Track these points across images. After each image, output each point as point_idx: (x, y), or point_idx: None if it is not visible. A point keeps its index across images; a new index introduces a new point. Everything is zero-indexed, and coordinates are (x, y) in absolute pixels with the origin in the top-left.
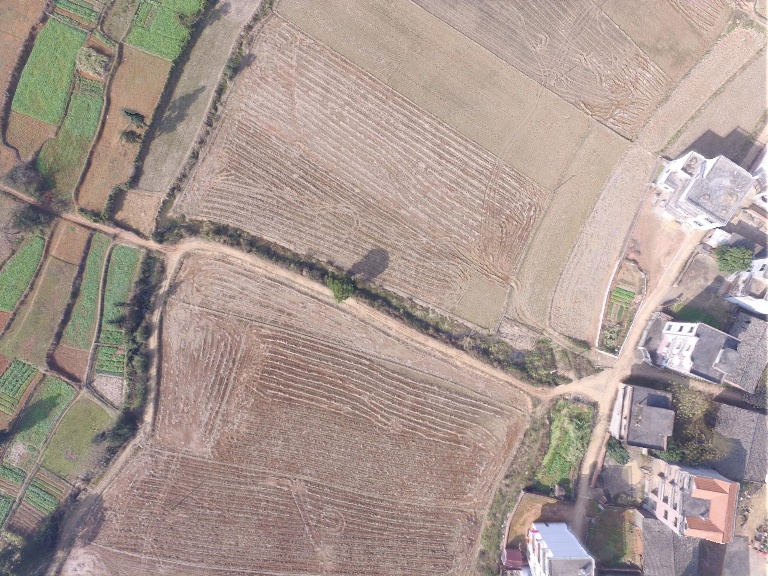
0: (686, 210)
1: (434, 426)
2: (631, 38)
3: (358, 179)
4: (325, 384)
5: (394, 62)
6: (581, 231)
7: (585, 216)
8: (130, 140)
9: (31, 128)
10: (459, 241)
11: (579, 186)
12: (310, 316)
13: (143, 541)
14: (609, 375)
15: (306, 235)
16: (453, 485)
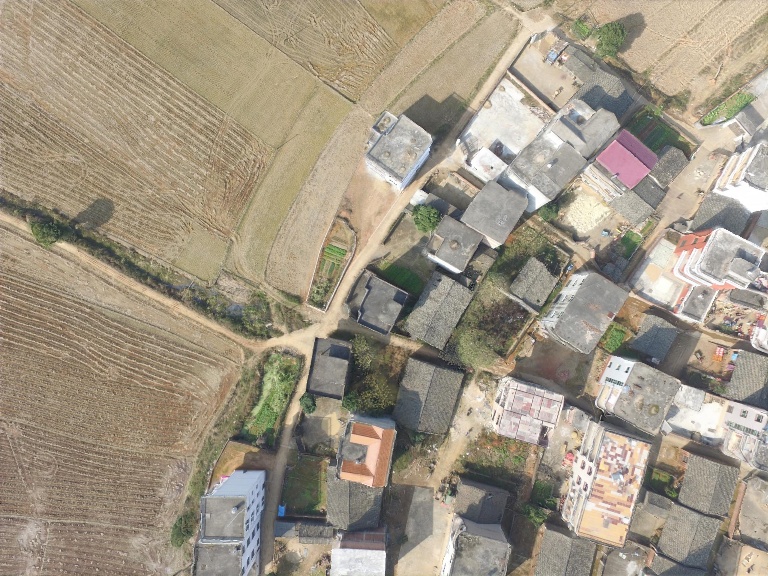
0: (376, 168)
1: (150, 374)
2: (360, 2)
3: (88, 129)
4: (45, 330)
5: (129, 15)
6: (300, 189)
7: (306, 174)
8: None
9: None
10: (184, 194)
11: (302, 145)
12: (34, 263)
13: None
14: (317, 329)
15: (34, 182)
16: (165, 432)
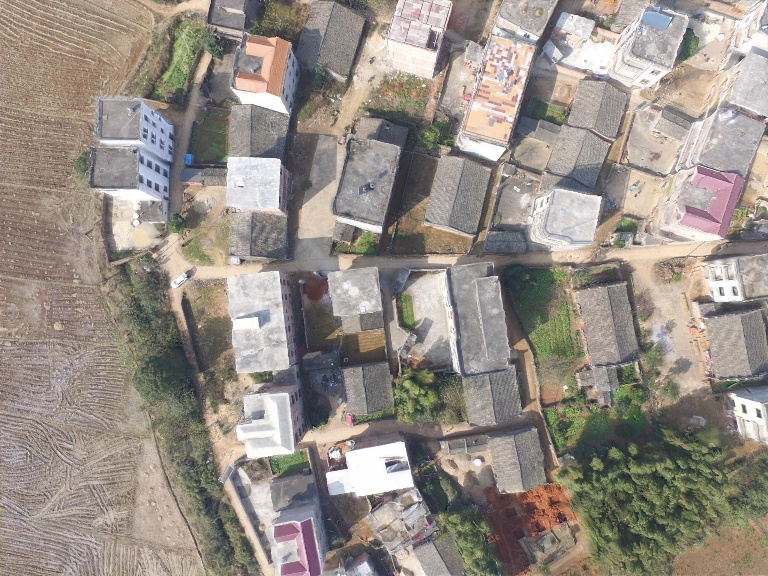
0: None
1: (61, 40)
2: None
3: None
4: None
5: None
6: None
7: None
8: None
9: None
10: None
11: None
12: None
13: None
14: None
15: None
16: (77, 96)
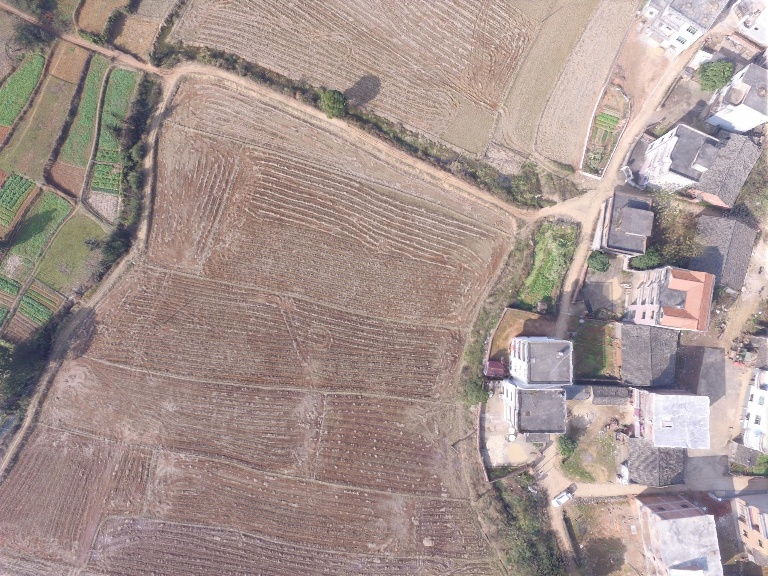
0: (669, 24)
1: (421, 247)
2: None
3: (352, 8)
4: (315, 205)
5: None
6: (568, 60)
7: (572, 46)
8: None
9: None
10: (449, 69)
11: (567, 17)
12: (302, 140)
13: (134, 354)
14: (592, 196)
15: (300, 62)
16: (438, 304)
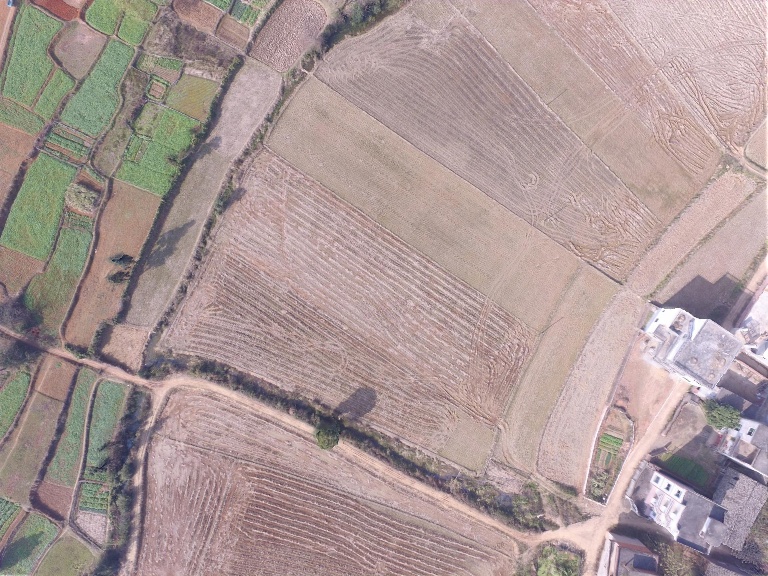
0: (674, 368)
1: (420, 569)
2: (621, 179)
3: (346, 316)
4: (310, 524)
5: (384, 199)
6: (569, 374)
7: (574, 359)
8: (117, 281)
9: (19, 263)
10: (447, 381)
11: (568, 328)
12: (296, 454)
13: None
14: (596, 523)
15: (293, 372)
16: None
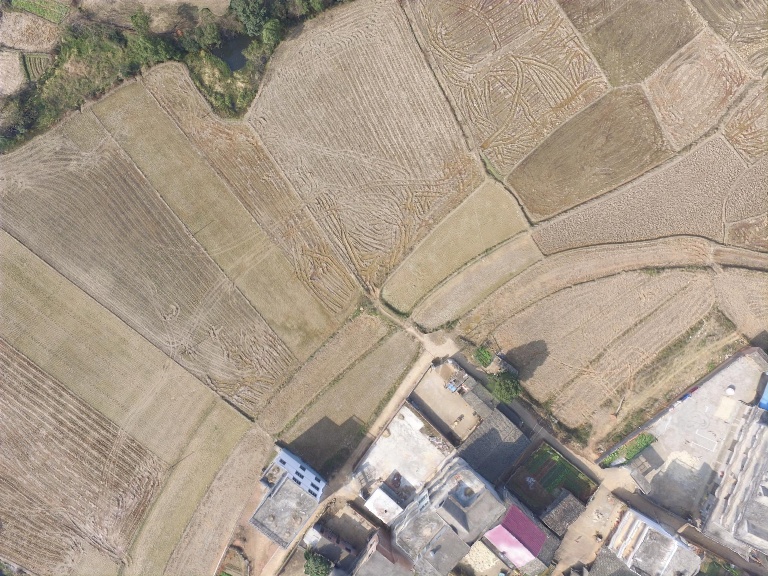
0: None
1: None
2: (261, 315)
3: None
4: None
5: (22, 324)
6: (195, 510)
7: (201, 494)
8: None
9: None
10: (75, 512)
11: (198, 463)
12: None
13: None
14: None
15: None
16: None
